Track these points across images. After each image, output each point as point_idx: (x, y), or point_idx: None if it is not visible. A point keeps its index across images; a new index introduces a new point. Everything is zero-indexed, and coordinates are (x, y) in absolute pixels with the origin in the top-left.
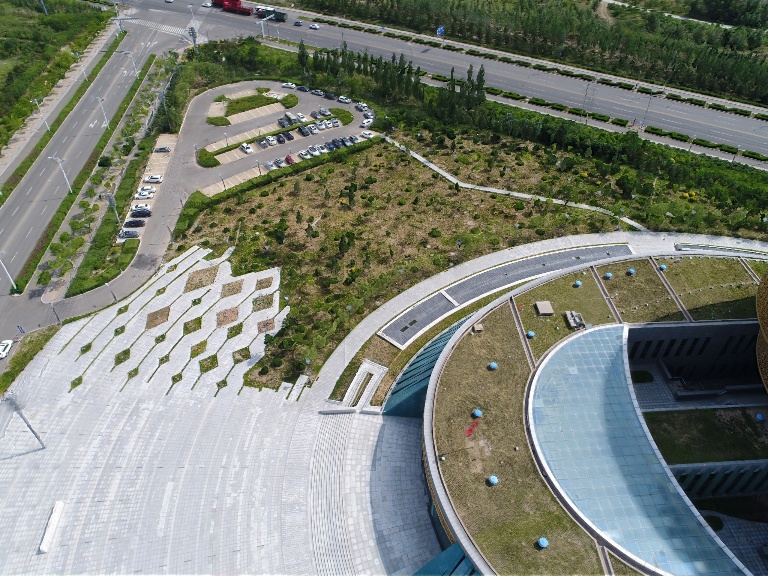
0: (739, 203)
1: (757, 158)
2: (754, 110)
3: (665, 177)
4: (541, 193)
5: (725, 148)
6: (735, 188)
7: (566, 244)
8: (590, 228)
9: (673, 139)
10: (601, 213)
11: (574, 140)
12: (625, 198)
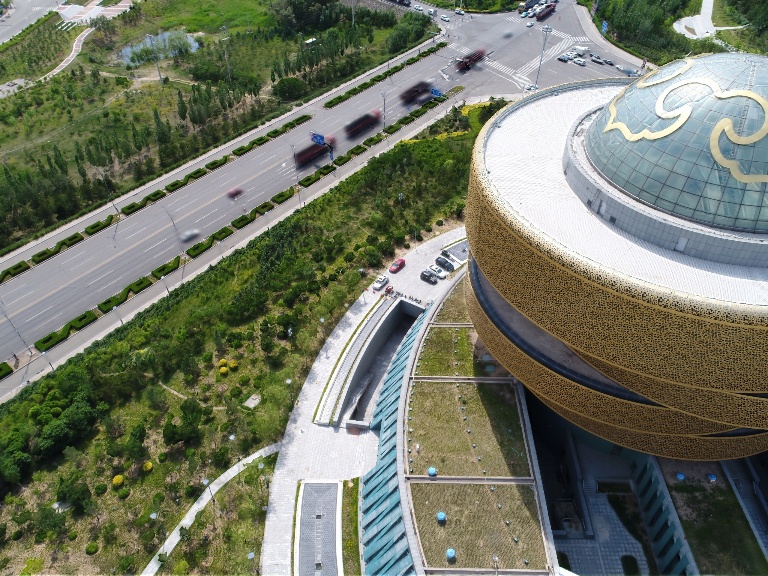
0: (251, 324)
1: (172, 270)
2: (74, 229)
3: (188, 379)
4: (130, 570)
5: (137, 288)
6: (226, 315)
7: (281, 574)
8: (251, 521)
9: (82, 329)
10: (221, 491)
11: (21, 462)
12: (197, 443)
